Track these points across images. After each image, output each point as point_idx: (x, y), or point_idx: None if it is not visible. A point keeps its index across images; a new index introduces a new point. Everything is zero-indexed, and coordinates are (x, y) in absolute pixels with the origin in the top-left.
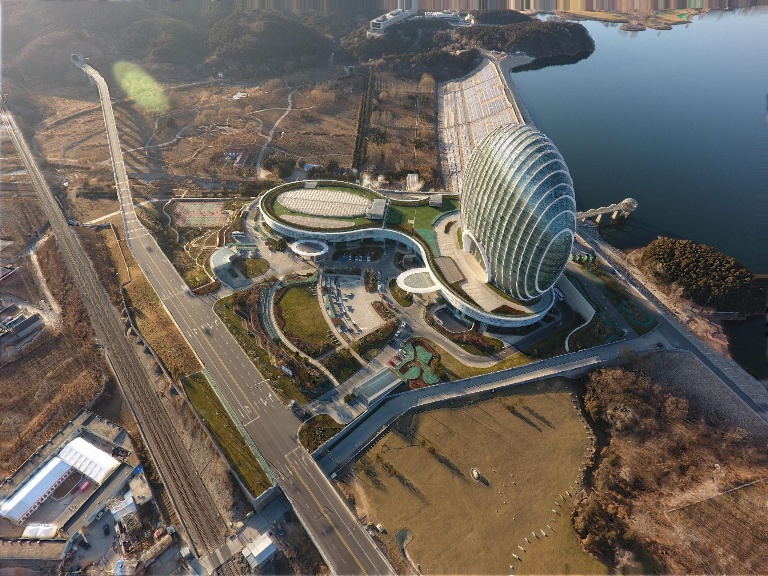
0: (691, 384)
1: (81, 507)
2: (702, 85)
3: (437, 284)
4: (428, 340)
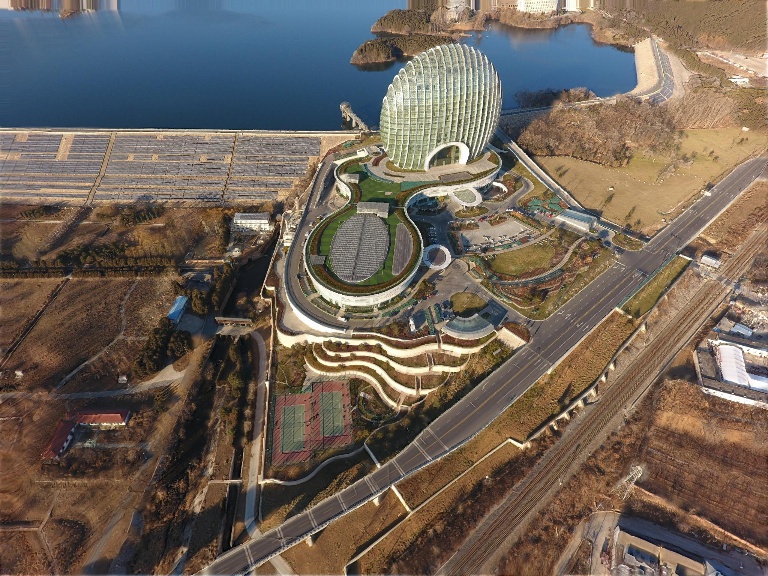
0: (513, 125)
1: (765, 351)
2: (149, 42)
3: (469, 187)
4: (520, 201)
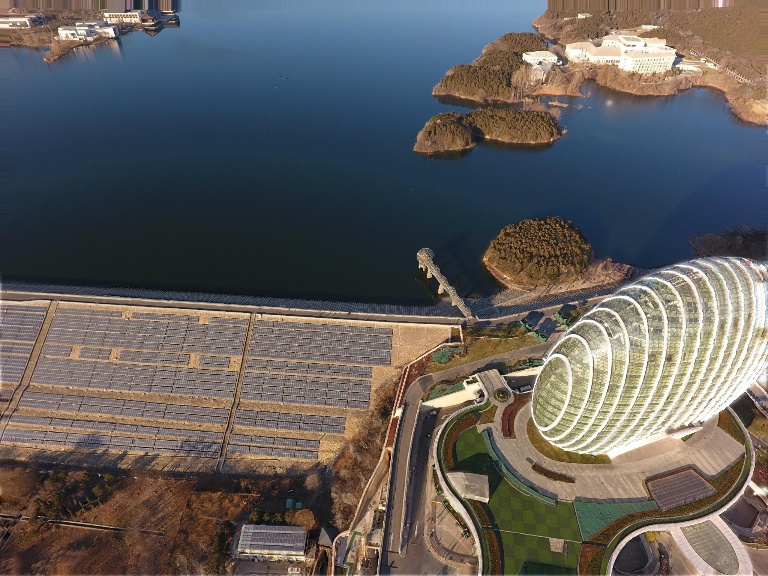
0: None
1: None
2: (139, 119)
3: None
4: None
